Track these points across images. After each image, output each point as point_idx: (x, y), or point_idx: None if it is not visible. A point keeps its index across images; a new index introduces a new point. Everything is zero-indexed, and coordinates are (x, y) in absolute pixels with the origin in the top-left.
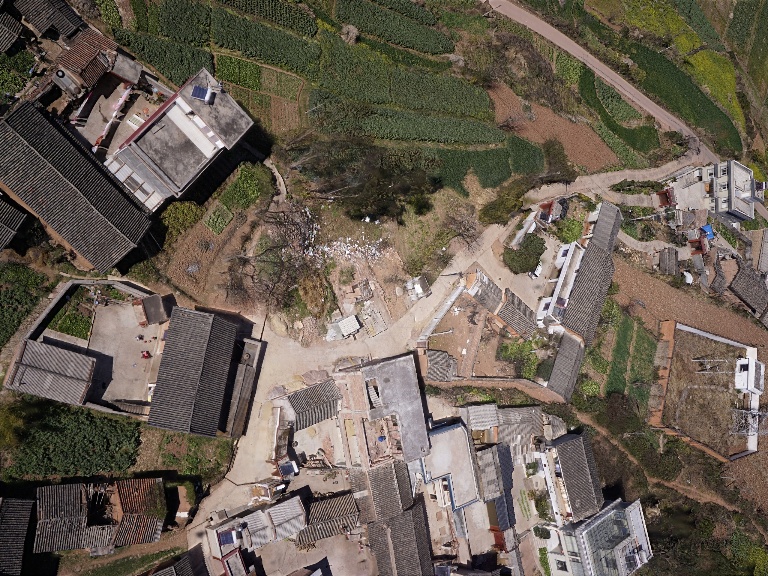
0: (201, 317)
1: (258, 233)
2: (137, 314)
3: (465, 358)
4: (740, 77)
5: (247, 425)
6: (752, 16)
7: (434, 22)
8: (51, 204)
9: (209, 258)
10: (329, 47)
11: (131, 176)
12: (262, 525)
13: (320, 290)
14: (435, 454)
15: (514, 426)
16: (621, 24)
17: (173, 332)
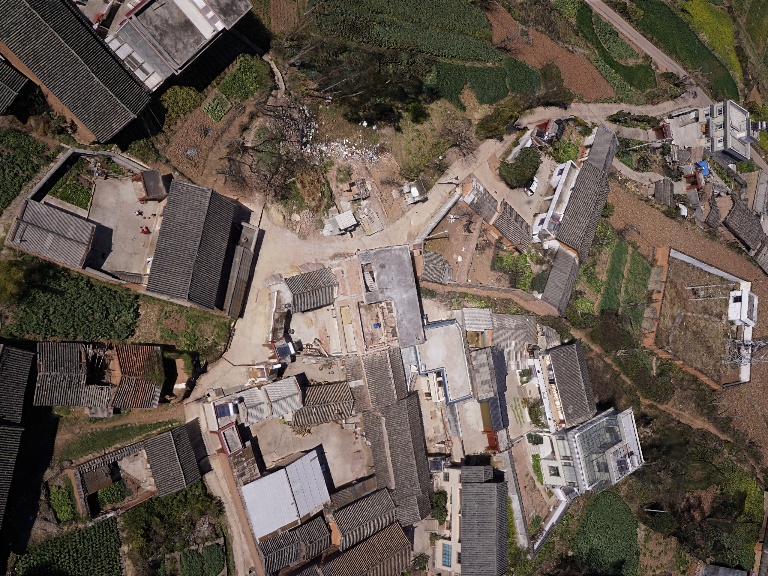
0: (200, 191)
1: (256, 124)
2: (136, 190)
3: (460, 265)
4: (738, 32)
5: (244, 308)
6: None
7: None
8: (52, 69)
9: (208, 144)
10: None
11: (131, 55)
12: (258, 401)
13: (317, 185)
14: (430, 347)
15: (508, 331)
16: None
17: (172, 204)
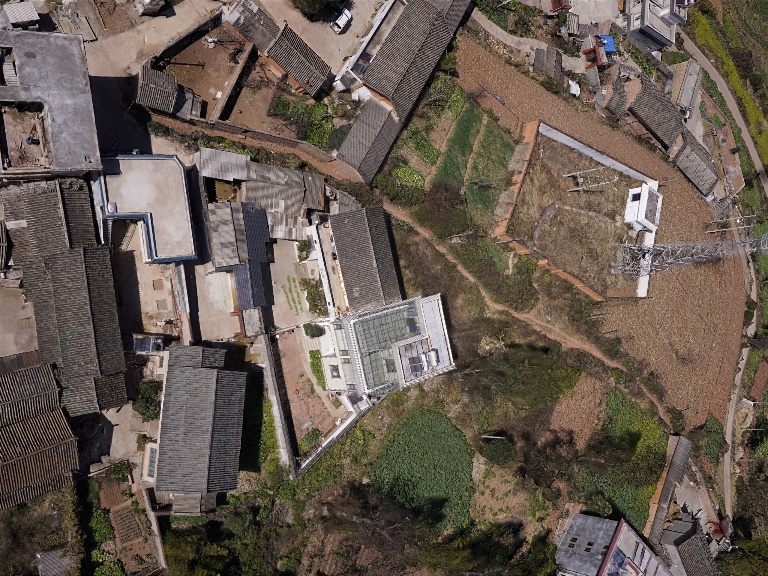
0: None
1: None
2: None
3: (218, 101)
4: None
5: None
6: None
7: None
8: None
9: None
10: None
11: None
12: None
13: None
14: (126, 183)
15: (274, 187)
16: None
17: None
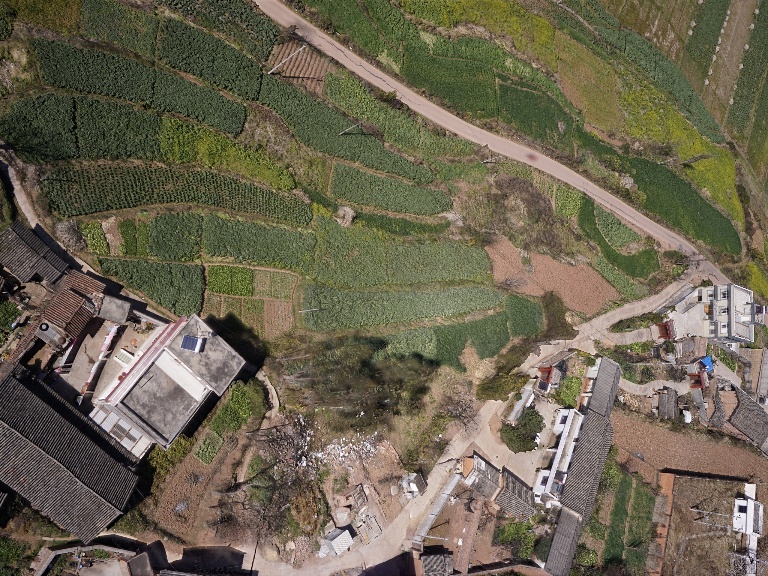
0: None
1: (249, 455)
2: (123, 569)
3: (461, 550)
4: (740, 168)
5: None
6: (752, 98)
7: (432, 179)
8: (33, 482)
9: (198, 492)
10: (324, 235)
11: (117, 423)
12: None
13: (313, 505)
14: None
15: None
16: (621, 138)
17: None
